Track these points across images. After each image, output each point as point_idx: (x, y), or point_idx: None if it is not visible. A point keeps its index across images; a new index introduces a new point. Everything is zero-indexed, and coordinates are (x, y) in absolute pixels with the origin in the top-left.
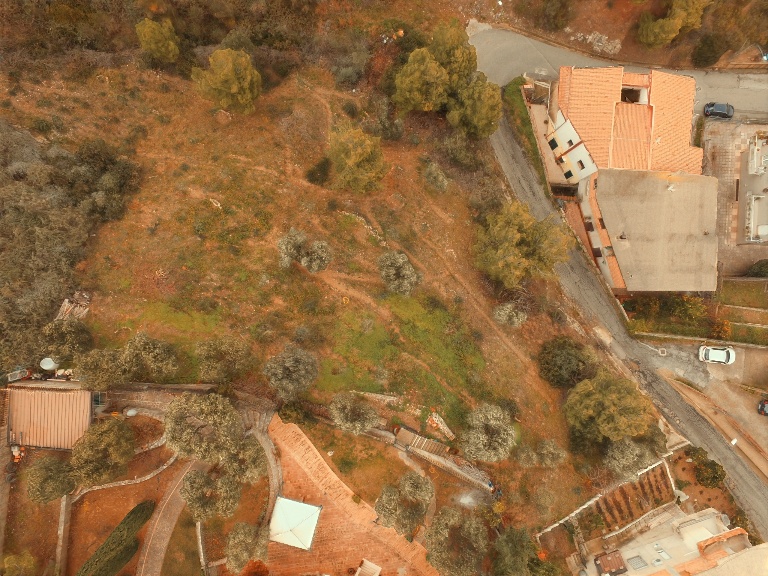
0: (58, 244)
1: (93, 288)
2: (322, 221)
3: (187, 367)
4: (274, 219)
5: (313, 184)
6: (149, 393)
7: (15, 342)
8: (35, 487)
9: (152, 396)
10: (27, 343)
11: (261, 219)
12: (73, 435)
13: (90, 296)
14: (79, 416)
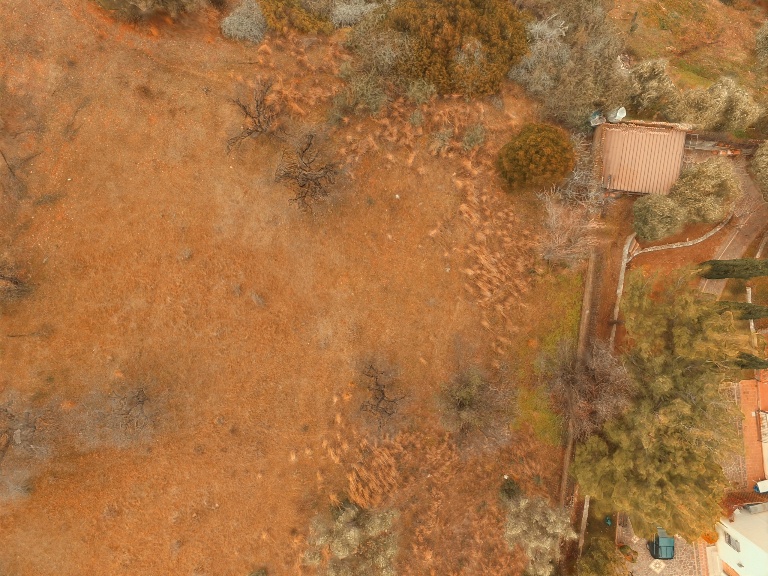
0: (598, 5)
1: (630, 52)
2: (755, 33)
3: (728, 133)
4: (722, 24)
5: (725, 5)
6: (698, 155)
7: (609, 80)
8: (665, 214)
9: (701, 158)
10: (624, 80)
11: (707, 24)
12: (663, 179)
13: (629, 59)
14: (671, 158)
